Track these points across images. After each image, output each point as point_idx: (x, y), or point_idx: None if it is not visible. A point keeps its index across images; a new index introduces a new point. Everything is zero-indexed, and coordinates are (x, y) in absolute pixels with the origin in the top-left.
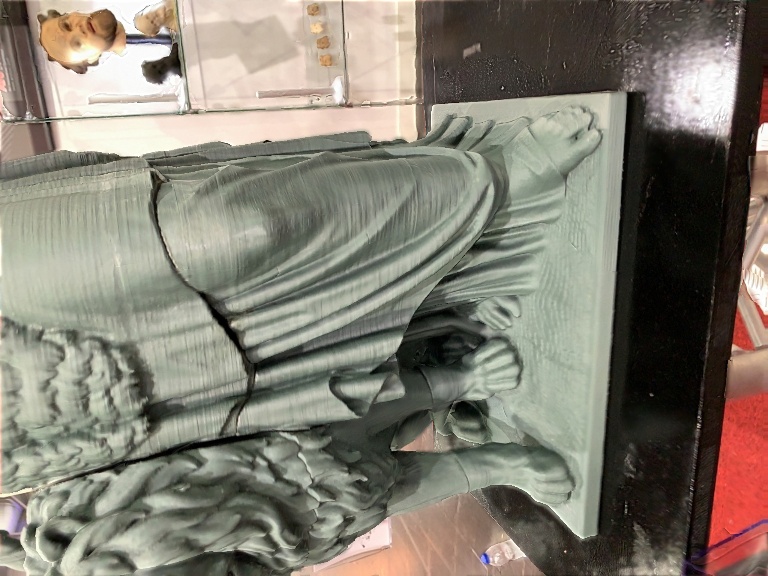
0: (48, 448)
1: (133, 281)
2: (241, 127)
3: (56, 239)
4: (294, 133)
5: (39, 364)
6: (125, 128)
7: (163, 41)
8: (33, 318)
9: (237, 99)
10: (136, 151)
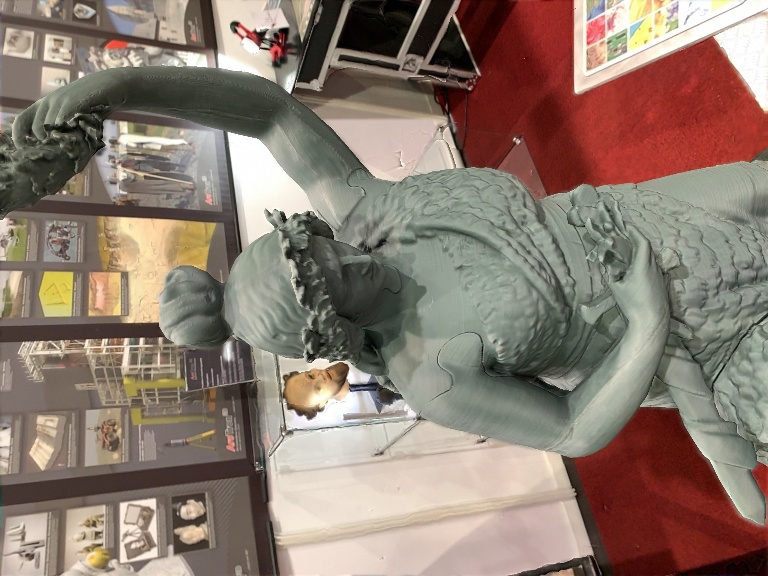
0: (754, 285)
1: (761, 185)
2: (421, 469)
3: (711, 170)
4: (464, 472)
5: (732, 228)
6: (325, 478)
7: (372, 388)
8: (715, 208)
9: (413, 447)
10: (335, 499)
